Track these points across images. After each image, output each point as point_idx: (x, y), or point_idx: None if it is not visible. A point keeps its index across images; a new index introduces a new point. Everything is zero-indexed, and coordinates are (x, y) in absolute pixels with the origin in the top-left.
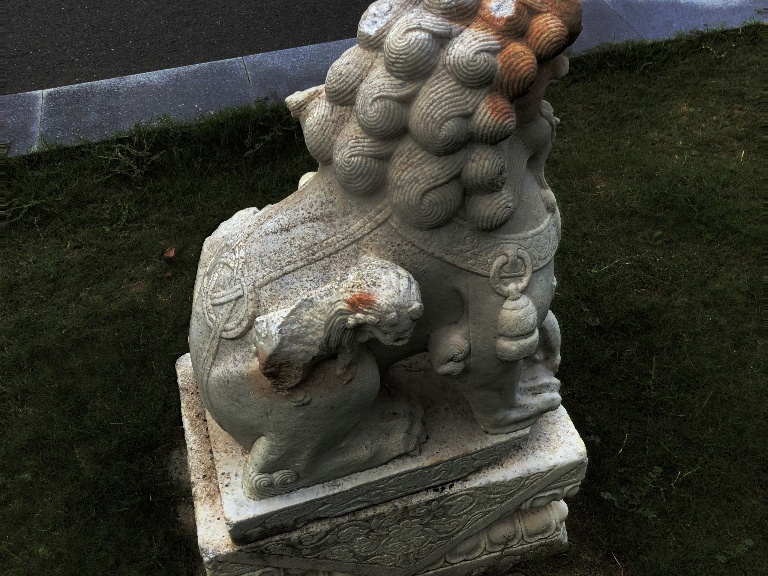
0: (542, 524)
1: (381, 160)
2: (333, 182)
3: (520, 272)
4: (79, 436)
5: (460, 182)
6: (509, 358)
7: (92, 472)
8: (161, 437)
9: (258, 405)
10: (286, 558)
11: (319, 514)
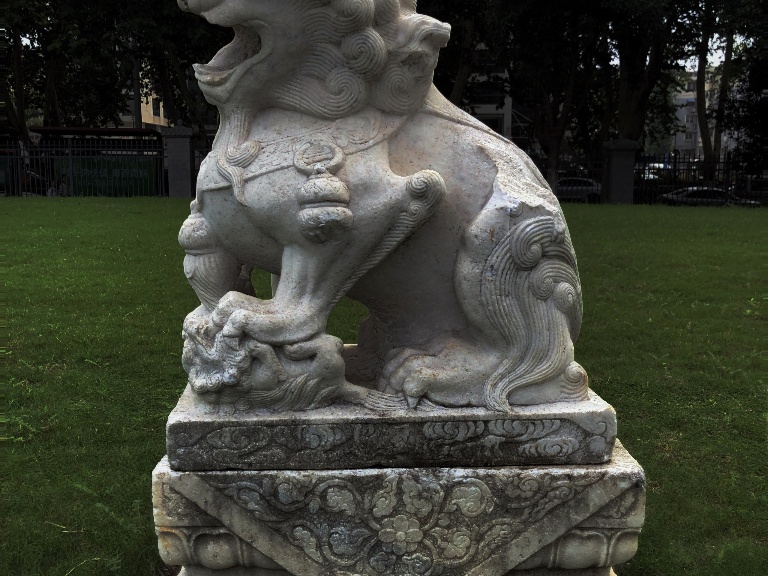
0: None
1: None
2: None
3: None
4: None
5: None
6: None
7: None
8: None
9: None
10: None
11: None
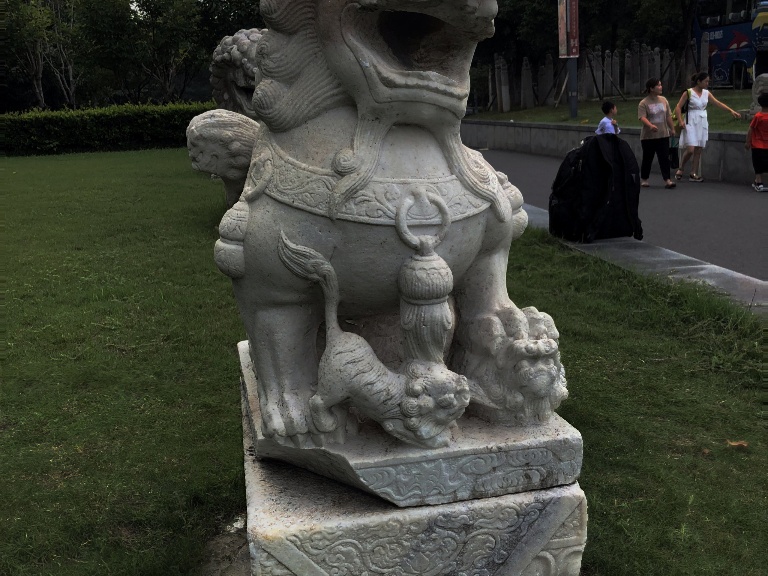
0: None
1: None
2: None
3: None
4: None
5: None
6: None
7: None
8: None
9: None
10: None
11: None
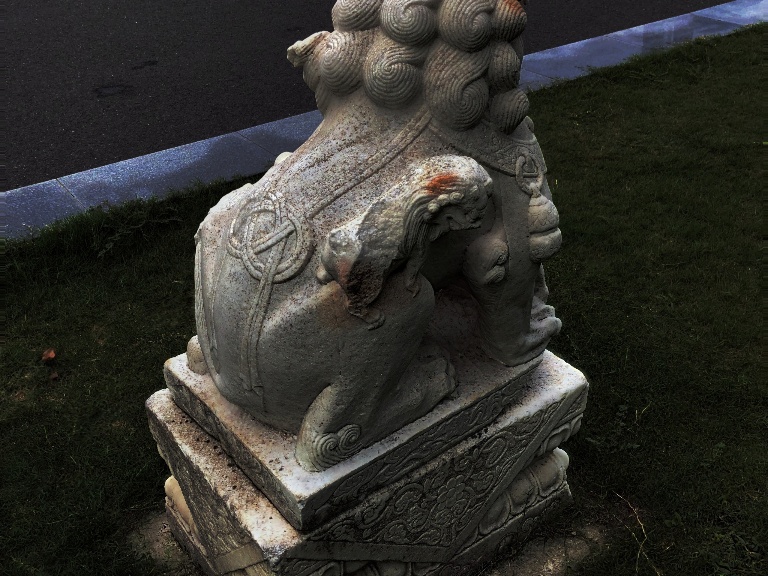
0: (553, 473)
1: (416, 67)
2: (364, 105)
3: (535, 173)
4: (14, 545)
5: (486, 80)
6: (543, 255)
7: (48, 573)
8: (115, 521)
9: (329, 341)
10: (348, 545)
11: (378, 480)
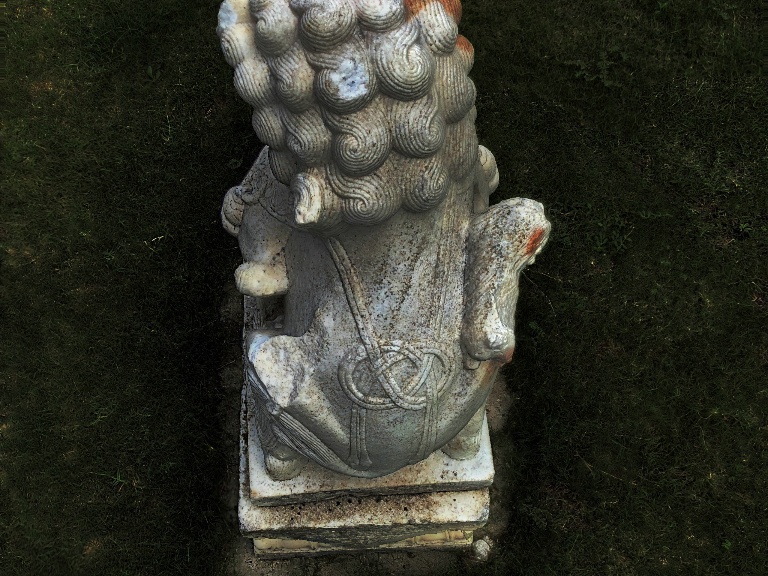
0: None
1: None
2: (407, 220)
3: None
4: None
5: None
6: None
7: None
8: None
9: (486, 392)
10: None
11: None
